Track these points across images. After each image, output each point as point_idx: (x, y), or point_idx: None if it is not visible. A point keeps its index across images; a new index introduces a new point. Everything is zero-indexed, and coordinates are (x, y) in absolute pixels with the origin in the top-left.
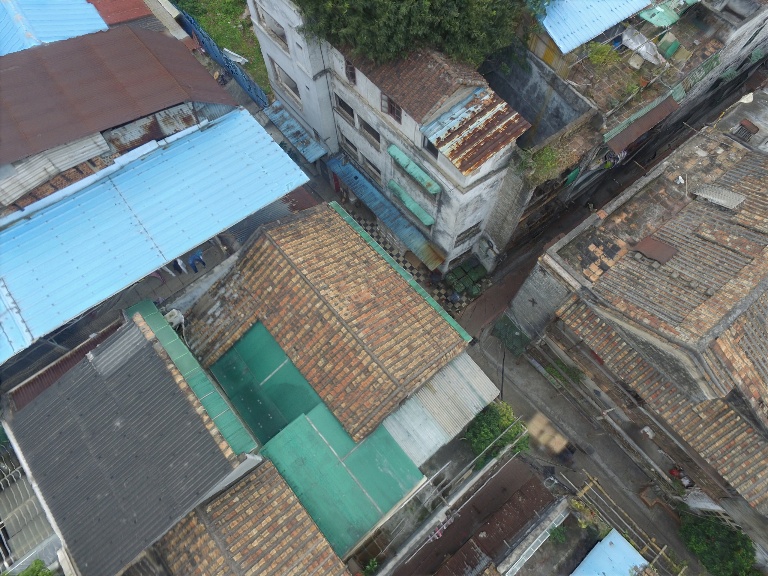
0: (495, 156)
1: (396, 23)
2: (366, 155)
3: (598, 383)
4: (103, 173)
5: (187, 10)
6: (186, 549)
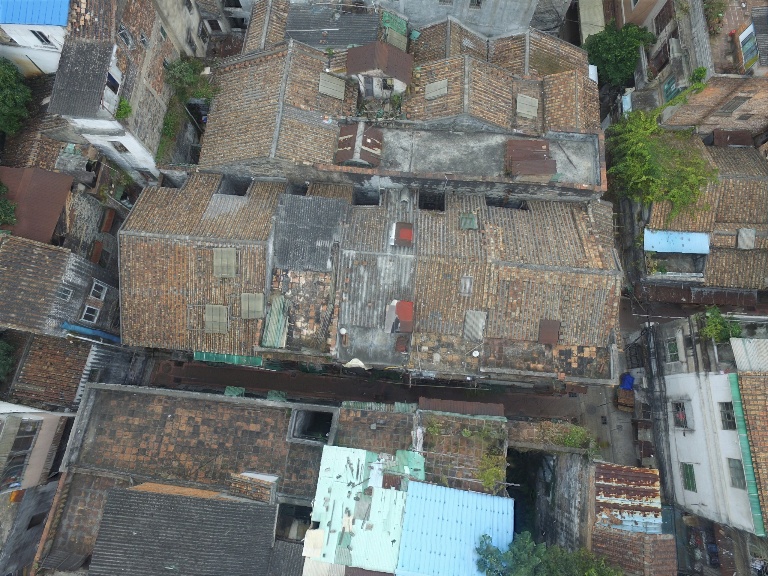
0: None
1: None
2: None
3: None
4: None
5: None
6: None
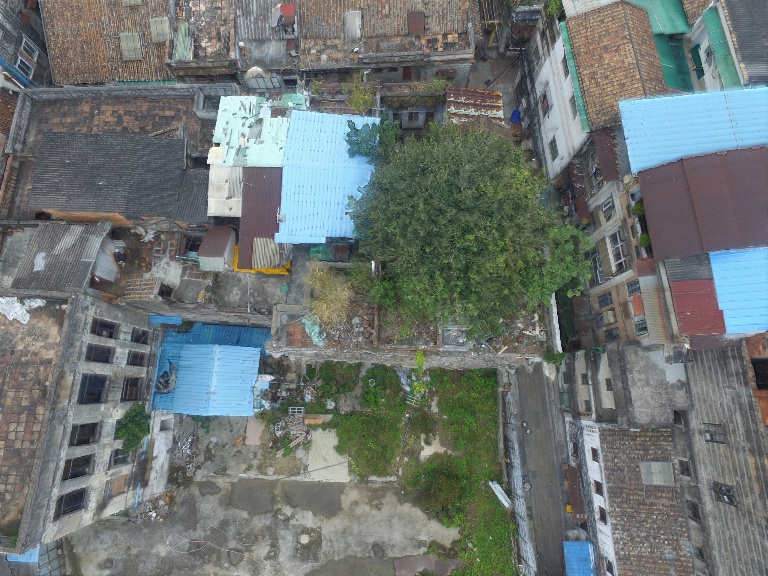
0: None
1: None
2: None
3: None
4: None
5: None
6: None
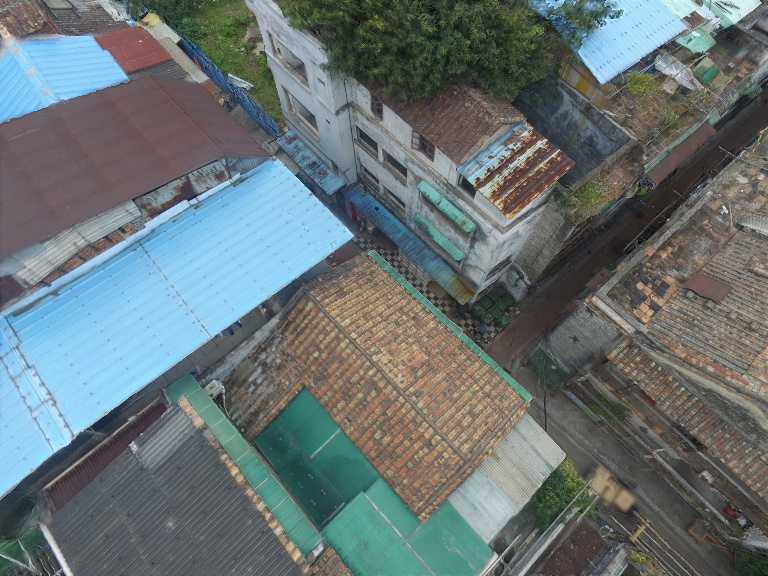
0: None
1: (433, 62)
2: (389, 187)
3: (650, 425)
4: (133, 239)
5: (187, 35)
6: None
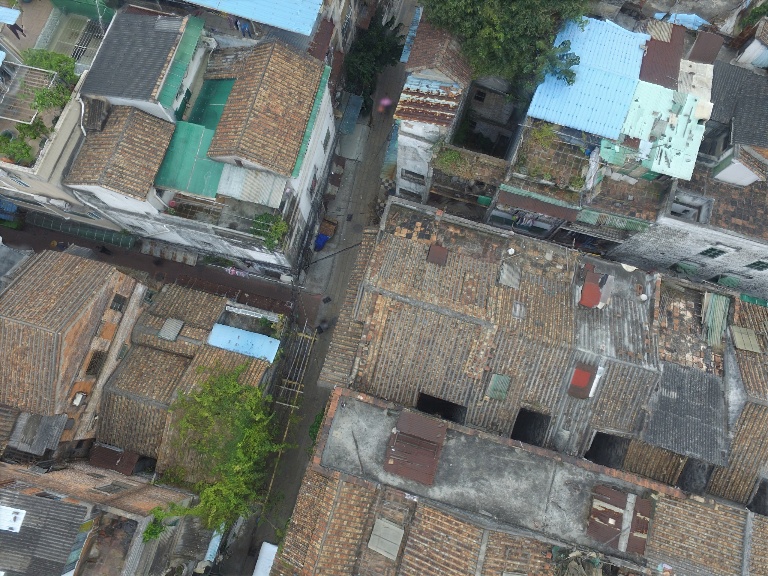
0: (425, 127)
1: (438, 2)
2: None
3: None
4: None
5: None
6: (118, 117)
